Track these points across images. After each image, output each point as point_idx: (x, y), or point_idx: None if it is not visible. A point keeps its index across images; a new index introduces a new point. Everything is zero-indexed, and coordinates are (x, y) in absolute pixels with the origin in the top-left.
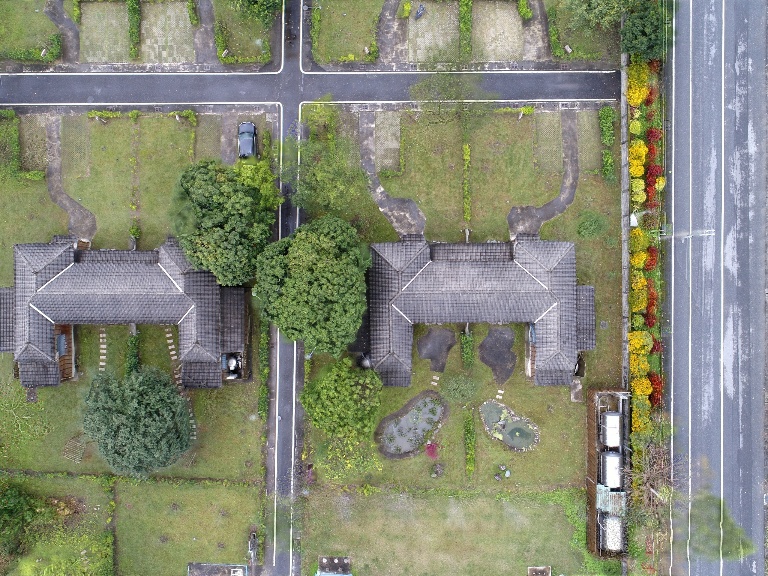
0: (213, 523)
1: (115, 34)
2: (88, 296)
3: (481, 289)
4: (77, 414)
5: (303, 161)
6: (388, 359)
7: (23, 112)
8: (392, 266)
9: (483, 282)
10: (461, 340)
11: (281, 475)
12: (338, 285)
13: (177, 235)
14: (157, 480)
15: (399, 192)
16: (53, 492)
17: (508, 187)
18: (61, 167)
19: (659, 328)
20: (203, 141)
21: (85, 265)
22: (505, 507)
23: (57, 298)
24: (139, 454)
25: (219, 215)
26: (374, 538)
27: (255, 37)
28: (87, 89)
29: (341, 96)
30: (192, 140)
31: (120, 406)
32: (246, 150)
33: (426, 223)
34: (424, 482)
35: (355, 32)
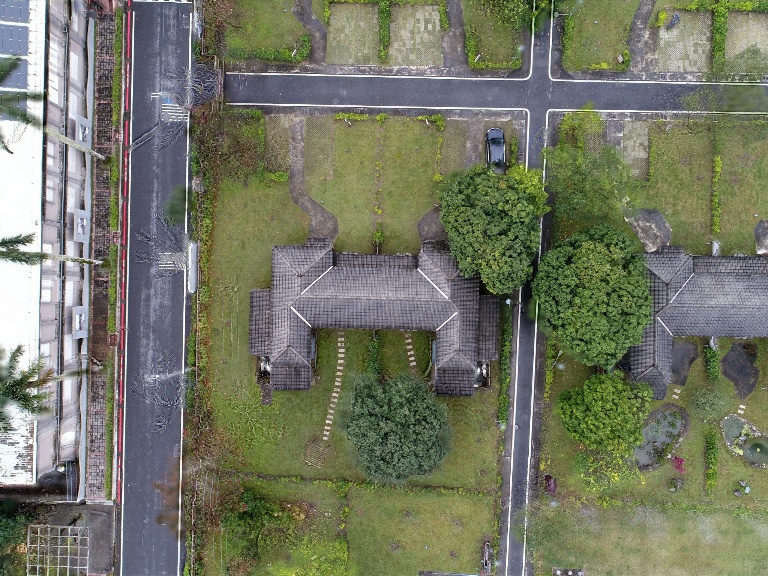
0: (446, 532)
1: (363, 36)
2: (352, 300)
3: (750, 303)
4: (312, 418)
5: (548, 169)
6: (650, 372)
7: (267, 112)
8: (660, 278)
9: (751, 296)
10: (707, 354)
11: (516, 485)
12: (637, 297)
13: (420, 240)
14: (392, 487)
15: (645, 202)
16: (284, 496)
17: (756, 200)
18: (304, 169)
19: None
20: (448, 146)
21: (344, 269)
22: (742, 523)
23: (320, 302)
24: (410, 462)
25: (502, 223)
26: (609, 551)
27: (504, 43)
28: (333, 91)
29: (589, 104)
30: (440, 145)
31: (386, 413)
32: (497, 156)
33: (672, 234)
34: (661, 496)
35: (606, 40)
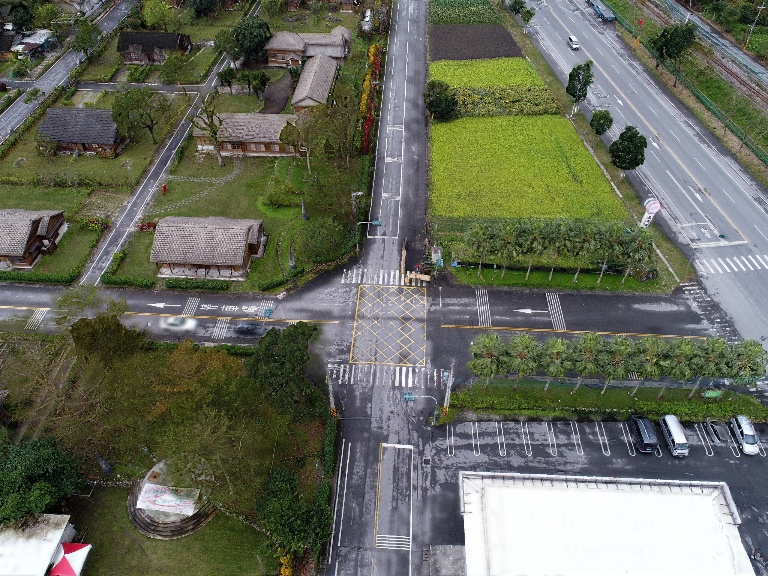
0: None
1: None
2: None
3: None
4: None
5: None
6: None
7: None
8: None
9: None
10: None
11: None
12: None
13: None
14: (197, 24)
15: None
16: None
17: None
18: None
19: (388, 4)
20: None
21: None
22: (327, 31)
23: None
24: None
25: None
26: None
27: None
28: None
29: None
30: None
31: None
32: None
33: None
34: None
35: None
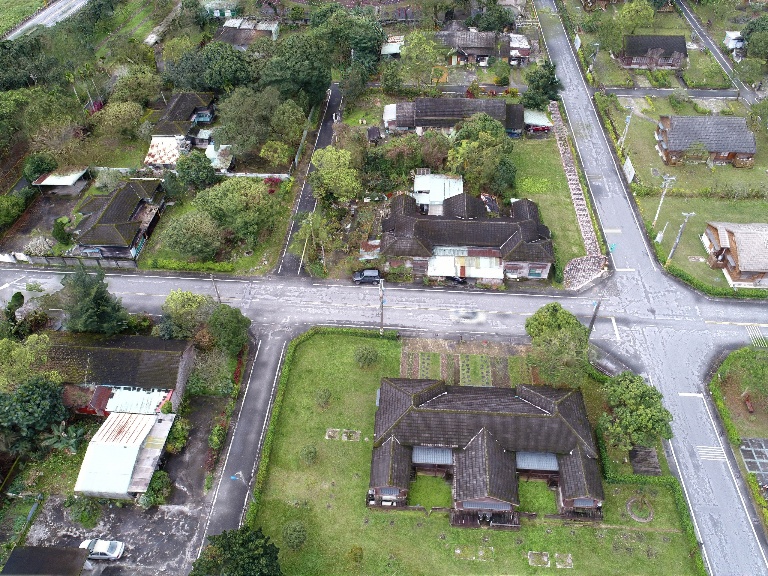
0: (673, 34)
1: None
2: None
3: None
4: None
5: None
6: None
7: None
8: None
9: None
10: (749, 4)
11: None
12: None
13: None
14: (646, 26)
15: None
16: None
17: None
18: None
19: None
20: None
21: None
22: None
23: None
24: None
25: None
26: None
27: None
28: None
29: None
30: None
31: None
32: None
33: None
34: None
35: None
